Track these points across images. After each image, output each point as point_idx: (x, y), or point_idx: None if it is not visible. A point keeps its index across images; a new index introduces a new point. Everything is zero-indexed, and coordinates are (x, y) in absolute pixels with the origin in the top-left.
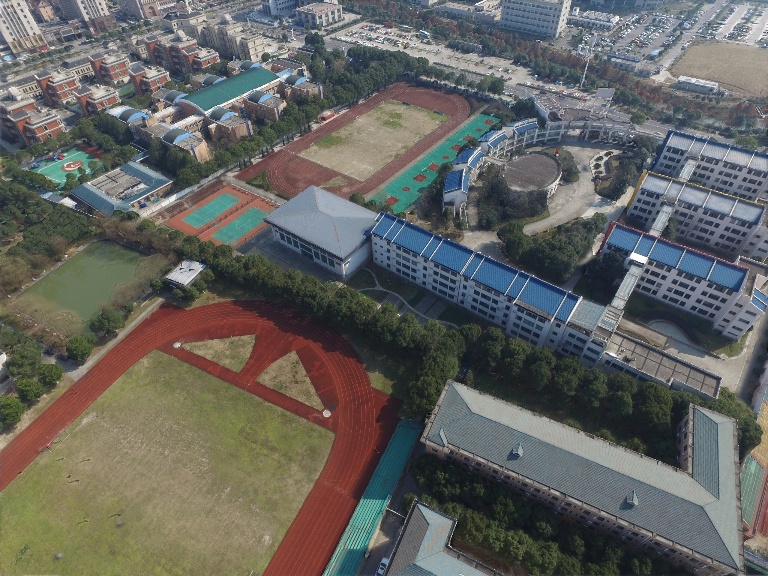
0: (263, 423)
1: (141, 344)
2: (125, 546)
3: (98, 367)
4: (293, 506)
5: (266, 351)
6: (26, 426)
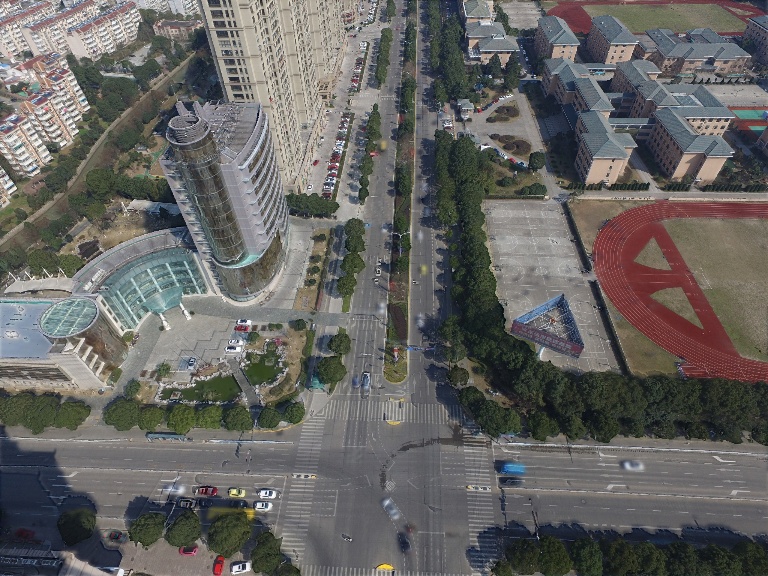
0: (736, 22)
1: (713, 2)
2: (678, 18)
3: (695, 0)
4: (728, 31)
5: (755, 16)
6: (666, 0)
